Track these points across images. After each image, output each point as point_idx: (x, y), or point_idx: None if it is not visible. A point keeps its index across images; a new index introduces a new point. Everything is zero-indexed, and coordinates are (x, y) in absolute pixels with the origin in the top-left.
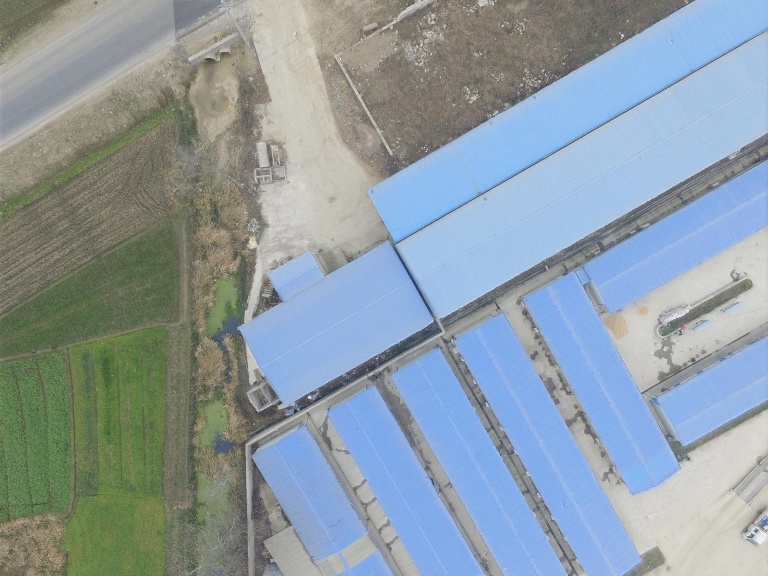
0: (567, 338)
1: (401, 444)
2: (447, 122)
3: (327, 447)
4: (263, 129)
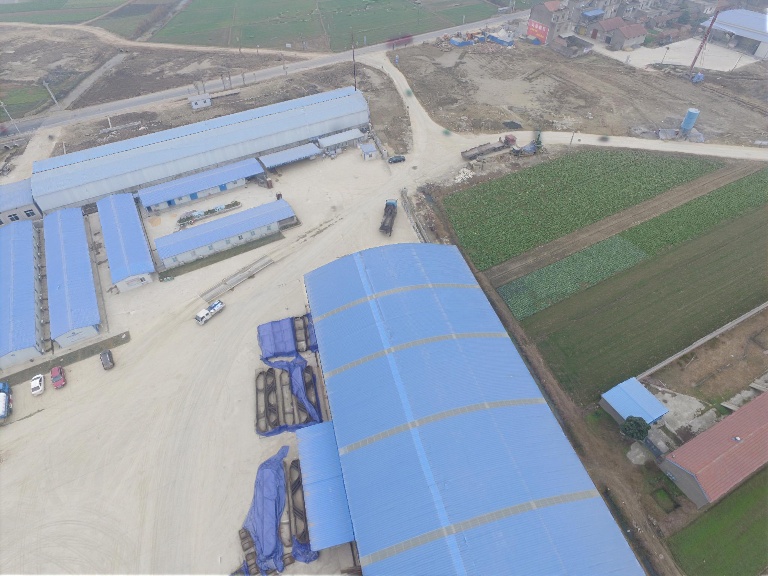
0: None
1: None
2: None
3: None
4: (10, 162)
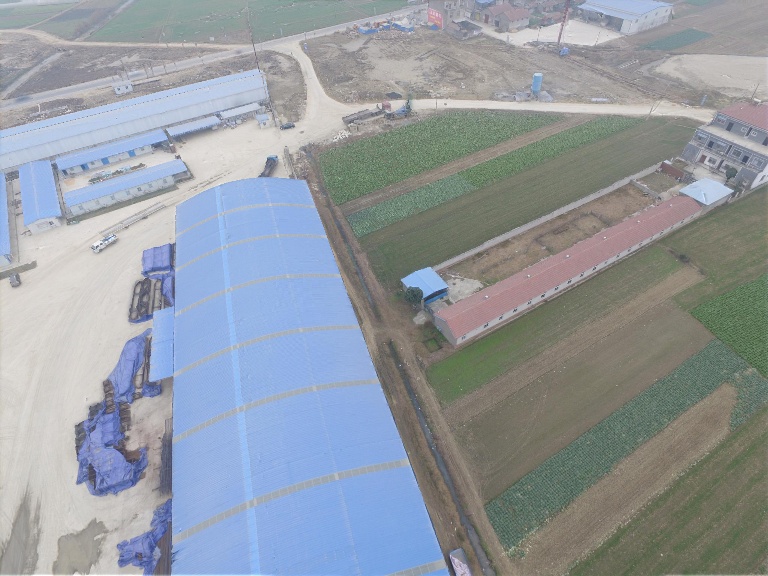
0: None
1: None
2: None
3: None
4: None
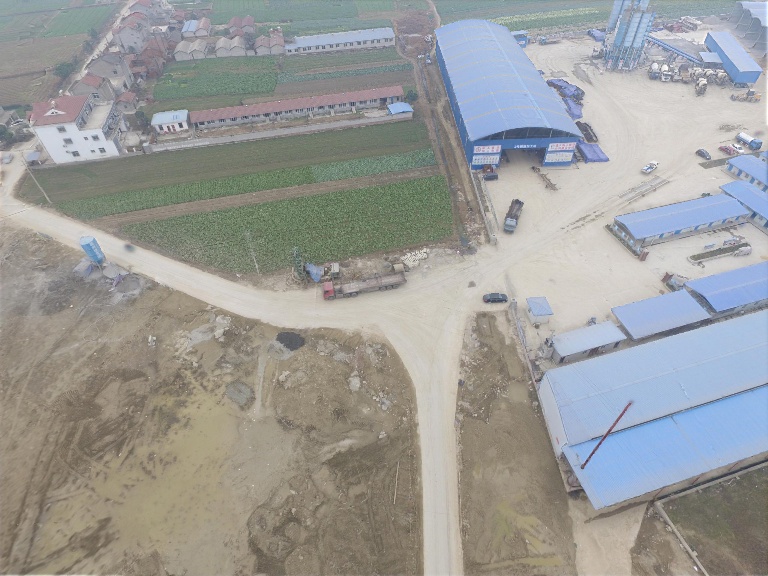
0: None
1: None
2: None
3: None
4: None
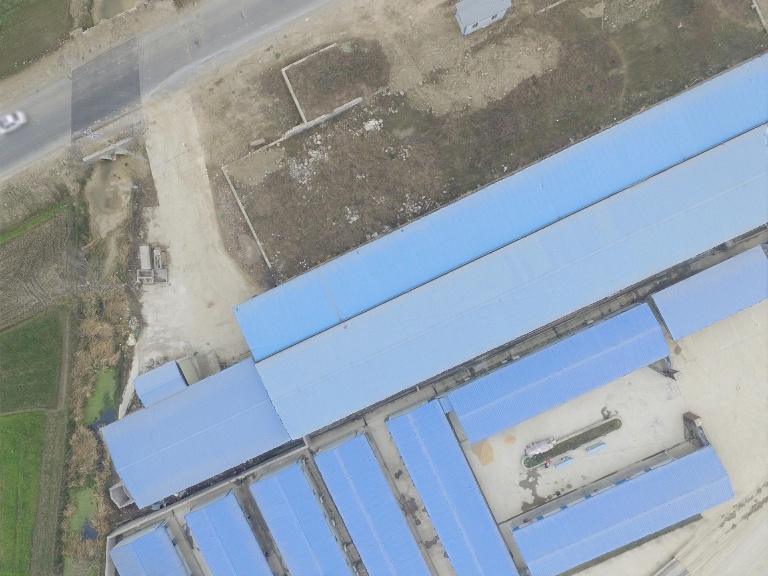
0: (425, 466)
1: (255, 554)
2: (326, 240)
3: (189, 545)
4: (149, 231)
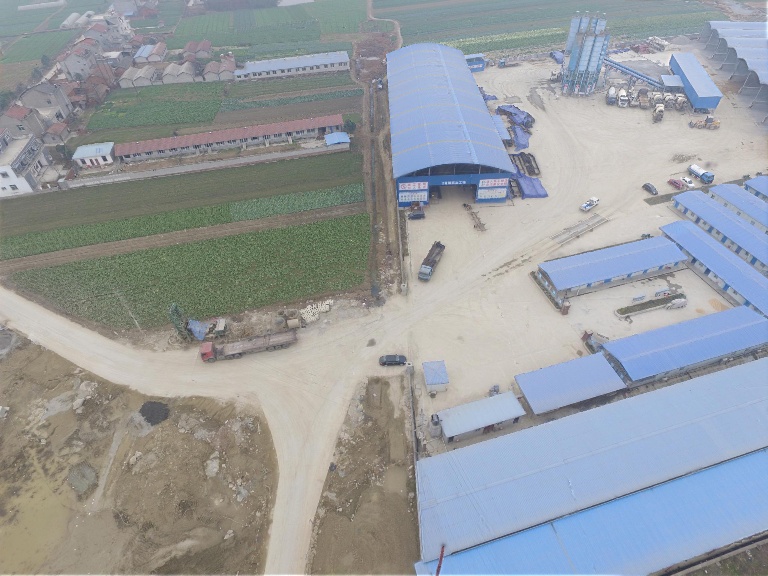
0: None
1: None
2: None
3: None
4: None
